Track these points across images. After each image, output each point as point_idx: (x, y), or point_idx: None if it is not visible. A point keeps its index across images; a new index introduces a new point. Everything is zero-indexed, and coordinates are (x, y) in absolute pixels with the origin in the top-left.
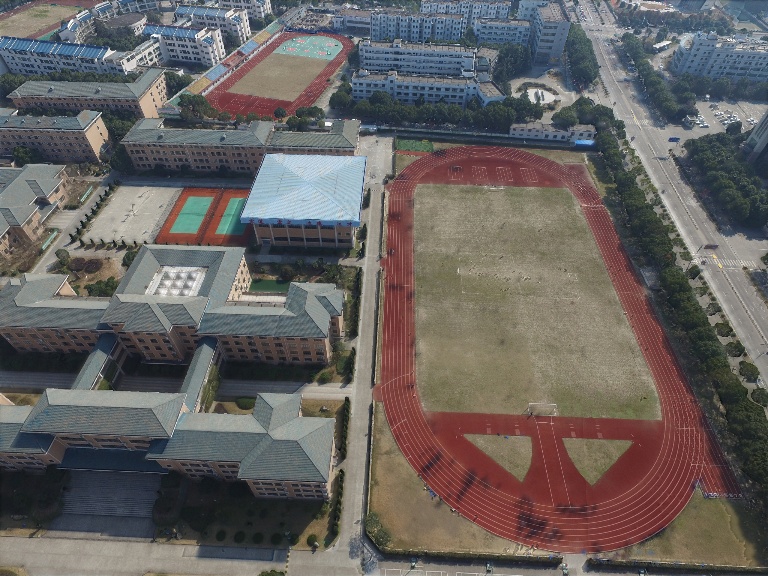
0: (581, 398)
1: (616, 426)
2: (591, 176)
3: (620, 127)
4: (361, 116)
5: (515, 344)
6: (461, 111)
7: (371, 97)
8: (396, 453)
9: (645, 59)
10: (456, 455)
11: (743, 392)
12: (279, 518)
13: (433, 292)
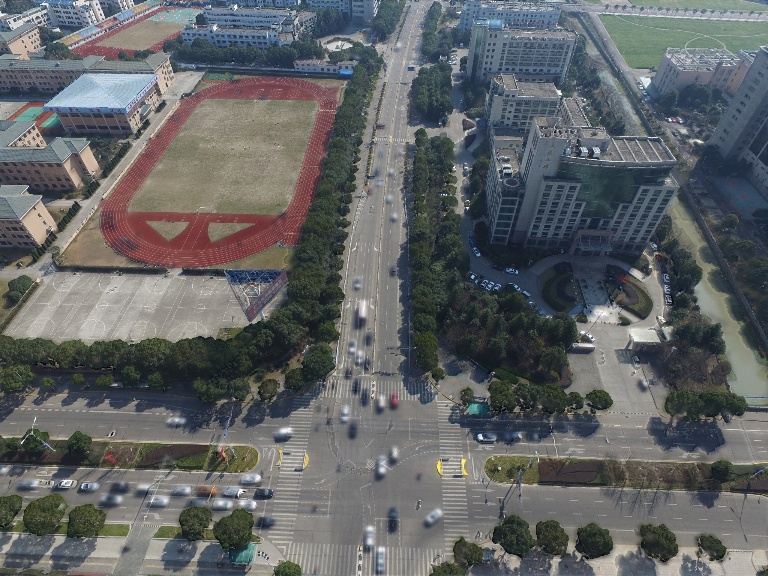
0: (237, 205)
1: (249, 217)
2: (340, 94)
3: (379, 62)
4: (183, 56)
5: (212, 181)
6: (256, 51)
7: (192, 43)
8: (96, 229)
9: (446, 22)
10: (135, 230)
11: (325, 191)
12: (5, 255)
13: (175, 156)
